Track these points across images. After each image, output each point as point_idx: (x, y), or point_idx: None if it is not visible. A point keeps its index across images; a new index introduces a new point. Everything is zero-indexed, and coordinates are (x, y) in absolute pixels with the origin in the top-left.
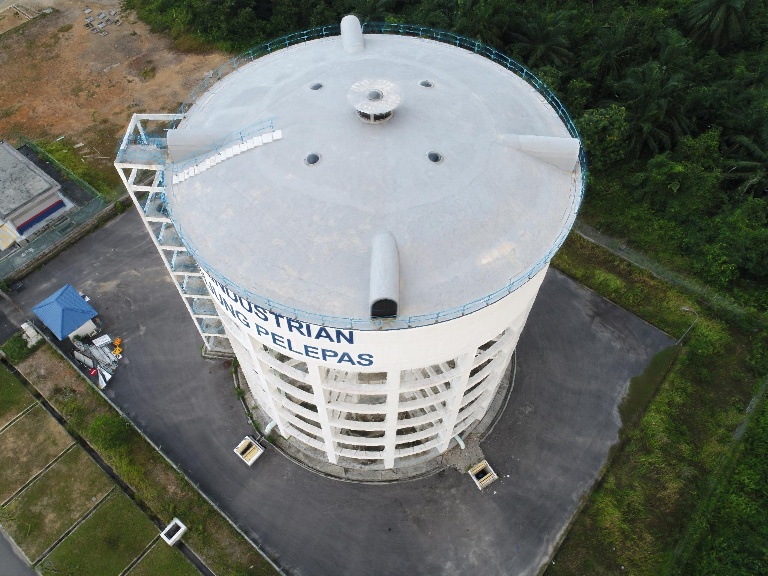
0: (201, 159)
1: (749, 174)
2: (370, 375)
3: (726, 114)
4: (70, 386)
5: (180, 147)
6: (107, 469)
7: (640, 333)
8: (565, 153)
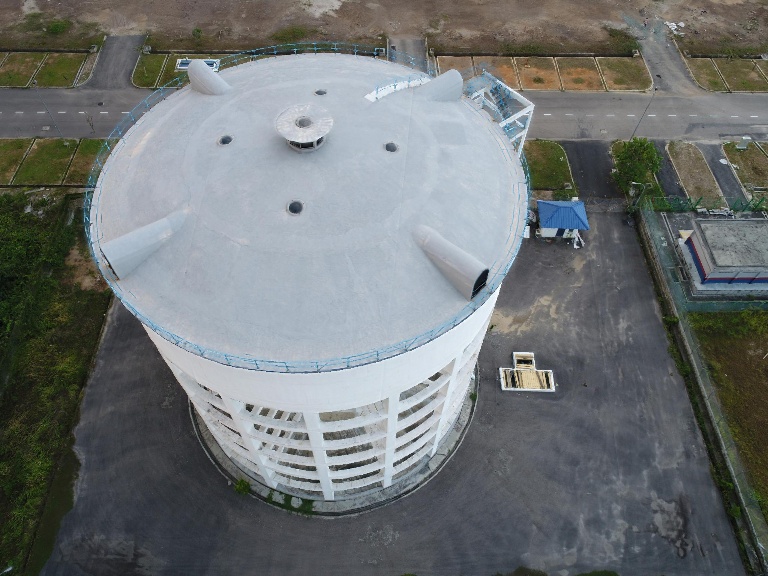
0: None
1: None
2: None
3: None
4: None
5: None
6: None
7: (73, 575)
8: None
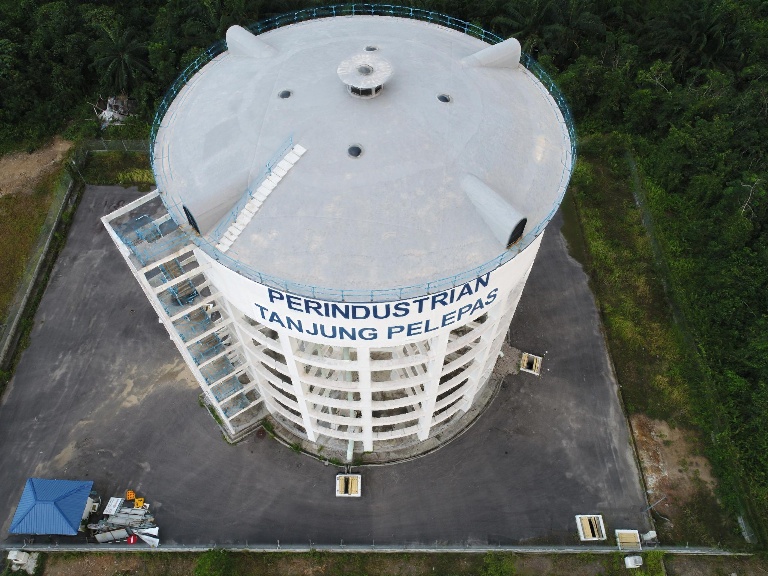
0: None
1: None
2: (391, 353)
3: (469, 8)
4: (118, 571)
5: (208, 213)
6: None
7: None
8: (512, 53)
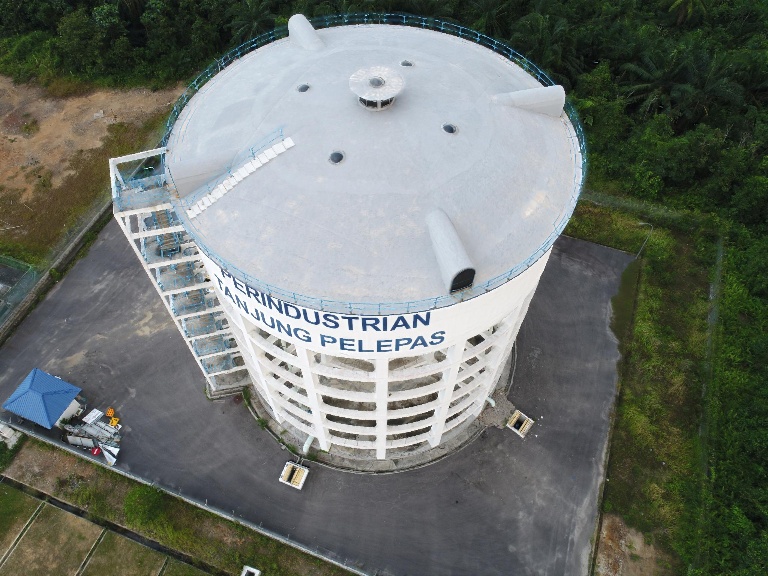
0: (212, 186)
1: (643, 96)
2: None
3: (606, 48)
4: (75, 474)
5: (187, 179)
6: (149, 544)
7: (603, 257)
8: (554, 100)
